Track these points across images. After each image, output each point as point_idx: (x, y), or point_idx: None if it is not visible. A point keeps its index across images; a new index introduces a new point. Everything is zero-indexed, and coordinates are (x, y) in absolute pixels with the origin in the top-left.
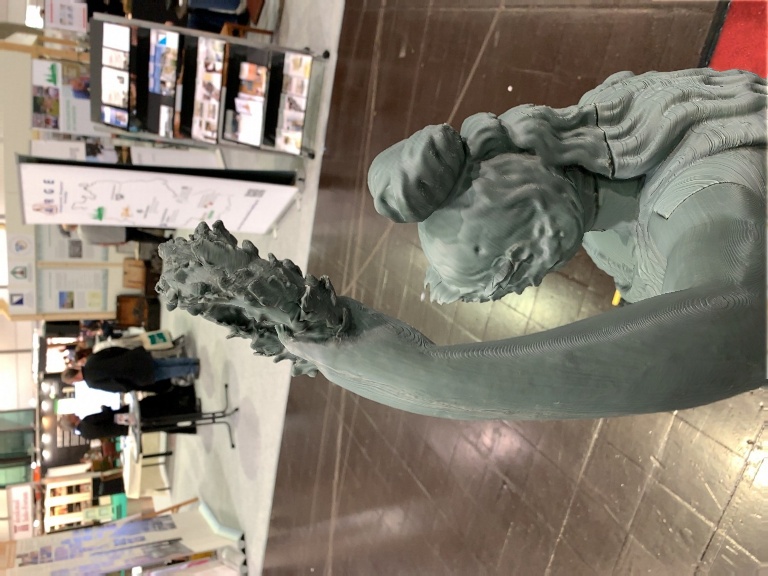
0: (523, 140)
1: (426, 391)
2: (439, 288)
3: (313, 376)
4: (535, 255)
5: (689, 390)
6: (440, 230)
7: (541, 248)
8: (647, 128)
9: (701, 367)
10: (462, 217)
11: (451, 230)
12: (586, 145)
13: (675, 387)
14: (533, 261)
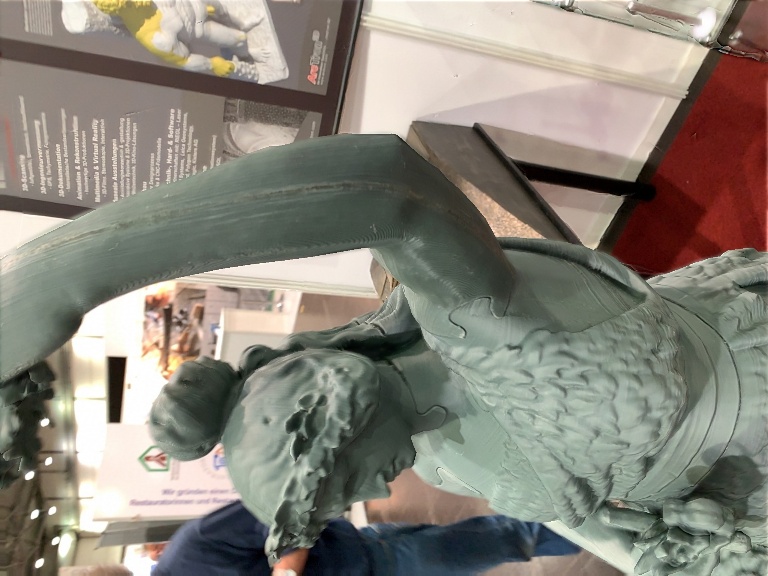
0: (287, 344)
1: (27, 247)
2: None
3: None
4: (327, 395)
5: (306, 153)
6: (231, 437)
7: (330, 387)
8: (391, 298)
9: (307, 143)
10: (243, 406)
11: (237, 424)
12: (349, 329)
13: (287, 154)
14: (328, 401)
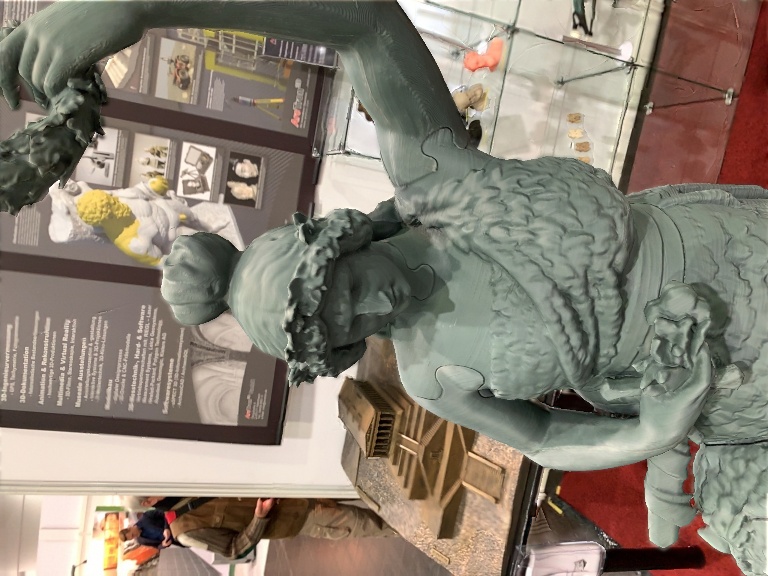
0: None
1: None
2: None
3: (45, 127)
4: None
5: None
6: (241, 268)
7: None
8: None
9: None
10: None
11: None
12: None
13: None
14: None
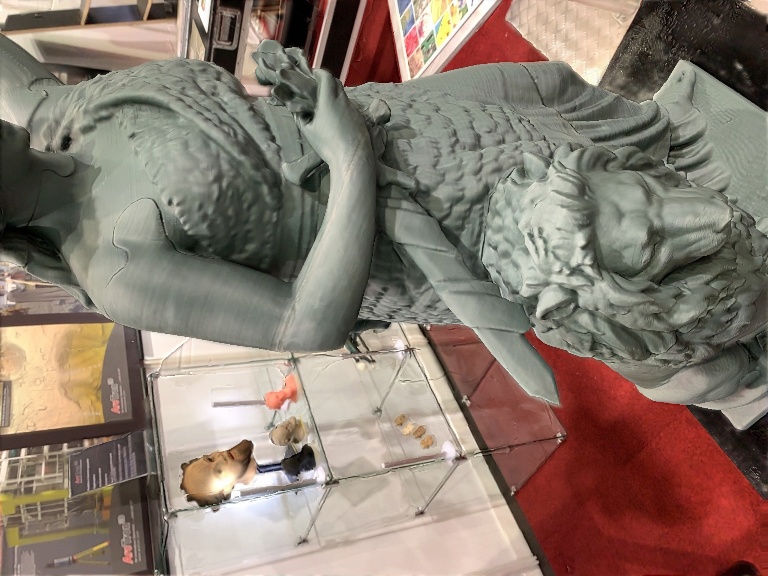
0: None
1: None
2: None
3: None
4: None
5: None
6: None
7: None
8: None
9: None
10: None
11: None
12: None
13: None
14: None
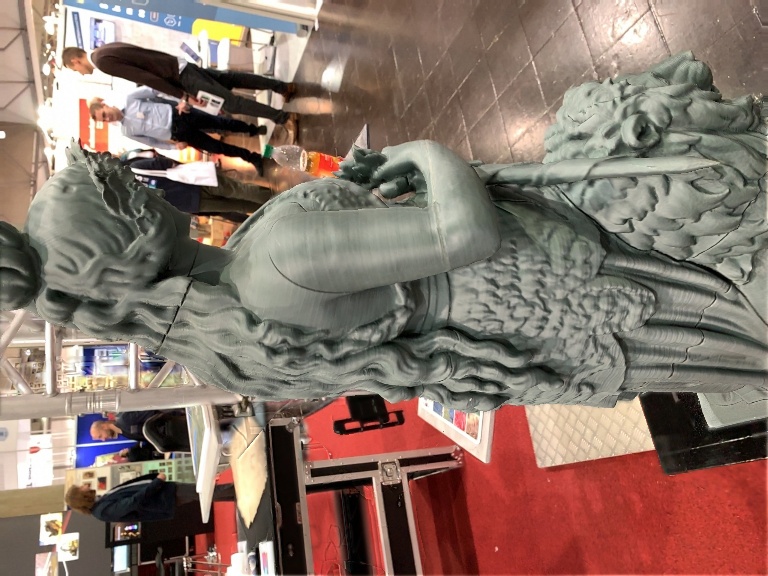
0: None
1: None
2: (70, 162)
3: None
4: None
5: None
6: None
7: None
8: None
9: None
10: None
11: None
12: None
13: None
14: None
